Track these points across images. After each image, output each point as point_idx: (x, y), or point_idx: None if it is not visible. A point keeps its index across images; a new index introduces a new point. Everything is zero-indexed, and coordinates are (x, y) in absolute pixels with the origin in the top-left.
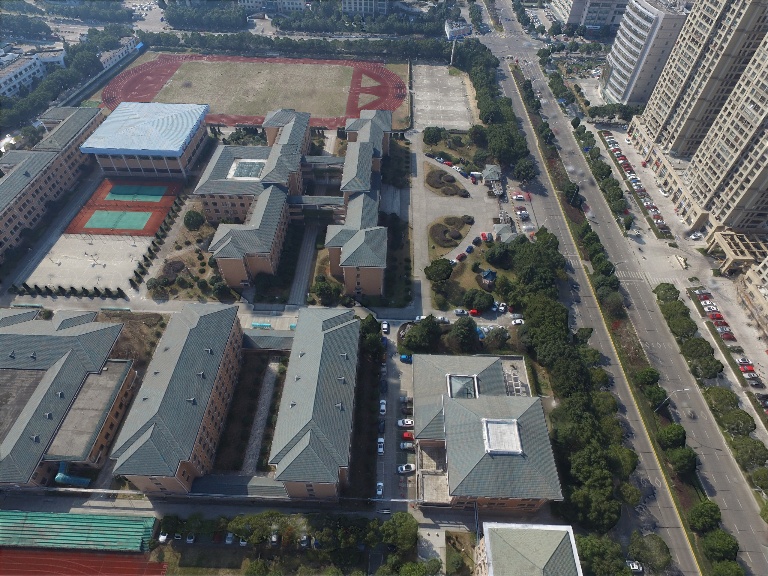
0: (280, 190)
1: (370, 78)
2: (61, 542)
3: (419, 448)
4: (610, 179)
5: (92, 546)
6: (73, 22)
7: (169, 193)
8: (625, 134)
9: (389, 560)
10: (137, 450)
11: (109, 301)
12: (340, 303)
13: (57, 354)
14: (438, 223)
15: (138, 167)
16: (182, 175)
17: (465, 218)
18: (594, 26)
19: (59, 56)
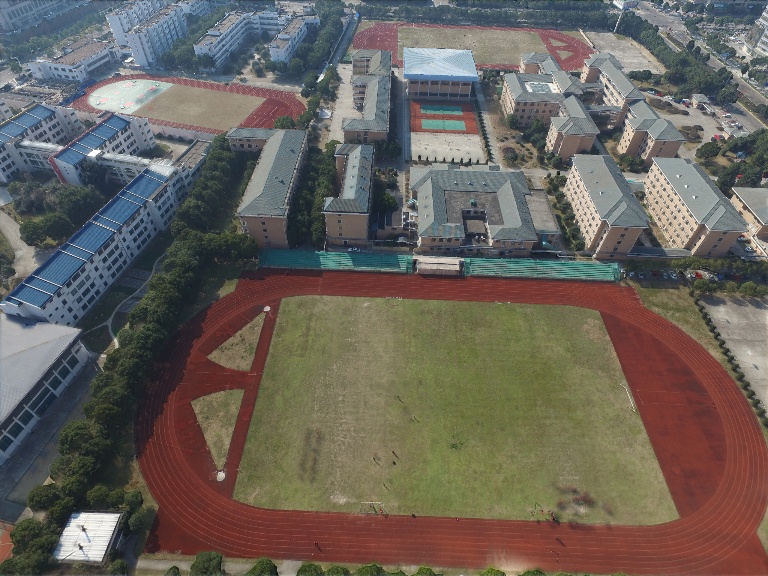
0: (578, 99)
1: (556, 40)
2: (564, 275)
3: (757, 237)
4: None
5: (584, 277)
6: None
7: (466, 110)
8: None
9: None
10: (622, 213)
11: None
12: (642, 171)
13: (500, 183)
14: (678, 129)
15: (436, 92)
16: (467, 99)
17: (697, 126)
18: (718, 5)
19: None
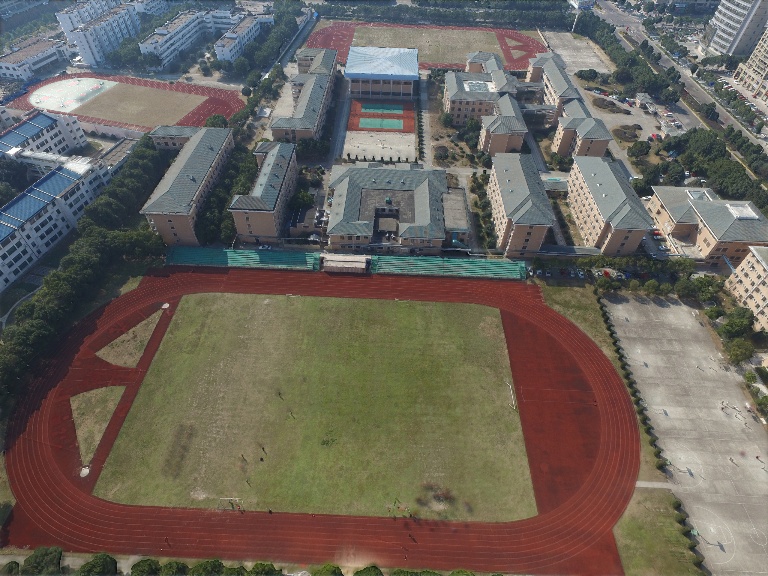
0: (512, 98)
1: (512, 40)
2: (470, 273)
3: (671, 235)
4: (739, 100)
5: (490, 275)
6: None
7: (407, 109)
8: (732, 78)
9: (682, 278)
10: (527, 211)
11: None
12: None
13: (418, 181)
14: (616, 128)
15: (378, 91)
16: (410, 98)
17: (636, 125)
18: (680, 5)
19: (272, 17)
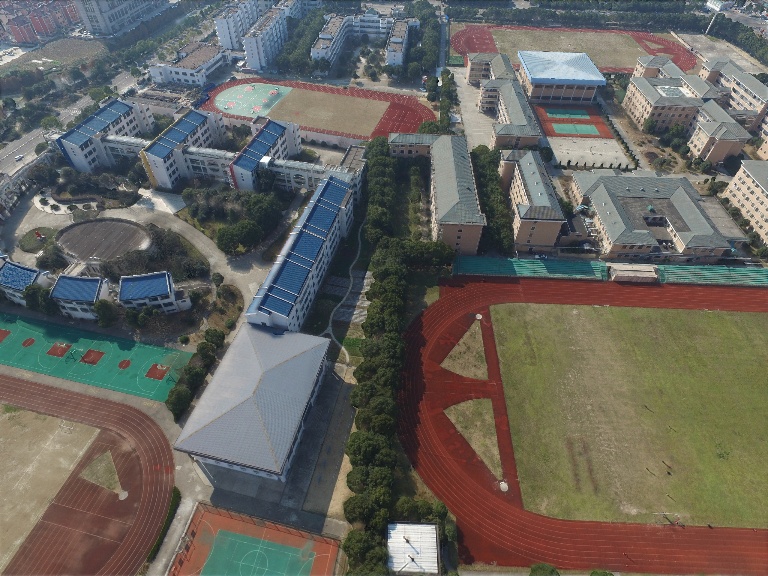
0: None
1: (652, 43)
2: (759, 283)
3: None
4: None
5: None
6: (362, 1)
7: (591, 114)
8: None
9: None
10: None
11: (630, 173)
12: None
13: (672, 189)
14: None
15: (559, 96)
16: (589, 103)
17: None
18: None
19: (419, 21)
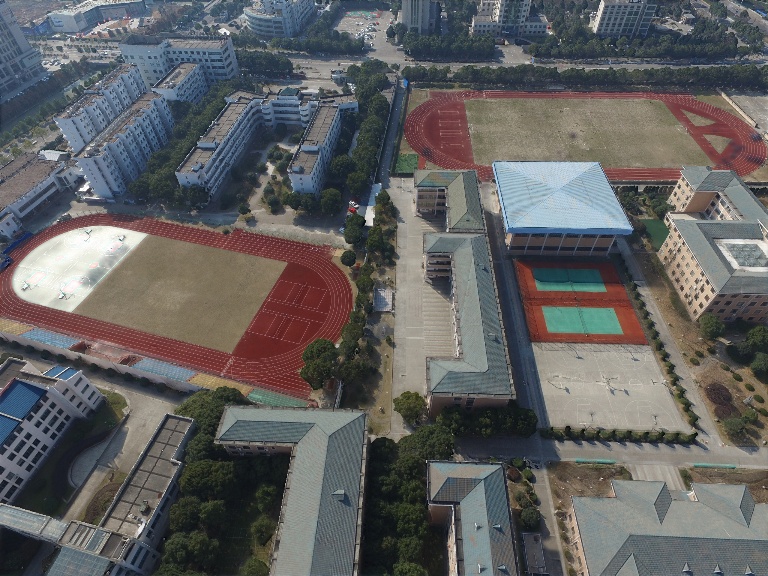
0: None
1: (695, 114)
2: None
3: None
4: None
5: None
6: (301, 56)
7: (608, 279)
8: None
9: None
10: None
11: (682, 450)
12: None
13: None
14: None
15: (555, 245)
16: (605, 253)
17: None
18: None
19: (357, 102)
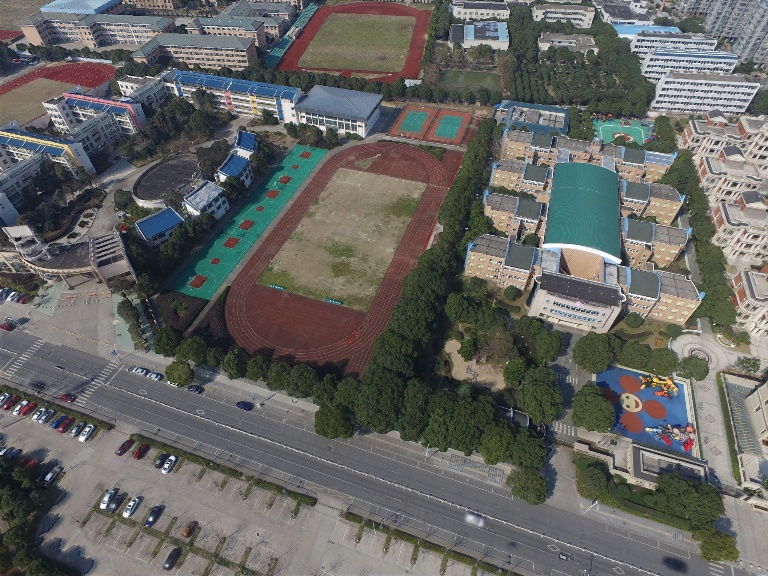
0: None
1: None
2: None
3: None
4: None
5: None
6: None
7: None
8: None
9: None
10: None
11: None
12: None
13: (248, 5)
14: None
15: None
16: None
17: None
18: None
19: None
